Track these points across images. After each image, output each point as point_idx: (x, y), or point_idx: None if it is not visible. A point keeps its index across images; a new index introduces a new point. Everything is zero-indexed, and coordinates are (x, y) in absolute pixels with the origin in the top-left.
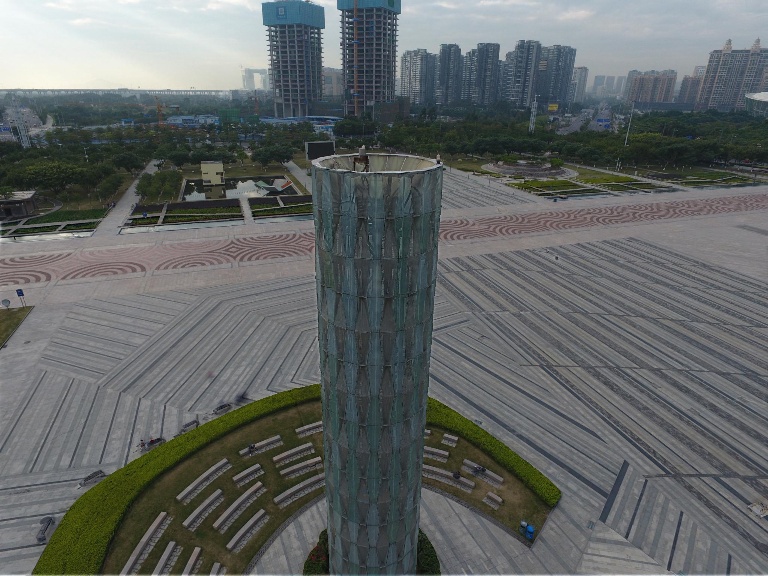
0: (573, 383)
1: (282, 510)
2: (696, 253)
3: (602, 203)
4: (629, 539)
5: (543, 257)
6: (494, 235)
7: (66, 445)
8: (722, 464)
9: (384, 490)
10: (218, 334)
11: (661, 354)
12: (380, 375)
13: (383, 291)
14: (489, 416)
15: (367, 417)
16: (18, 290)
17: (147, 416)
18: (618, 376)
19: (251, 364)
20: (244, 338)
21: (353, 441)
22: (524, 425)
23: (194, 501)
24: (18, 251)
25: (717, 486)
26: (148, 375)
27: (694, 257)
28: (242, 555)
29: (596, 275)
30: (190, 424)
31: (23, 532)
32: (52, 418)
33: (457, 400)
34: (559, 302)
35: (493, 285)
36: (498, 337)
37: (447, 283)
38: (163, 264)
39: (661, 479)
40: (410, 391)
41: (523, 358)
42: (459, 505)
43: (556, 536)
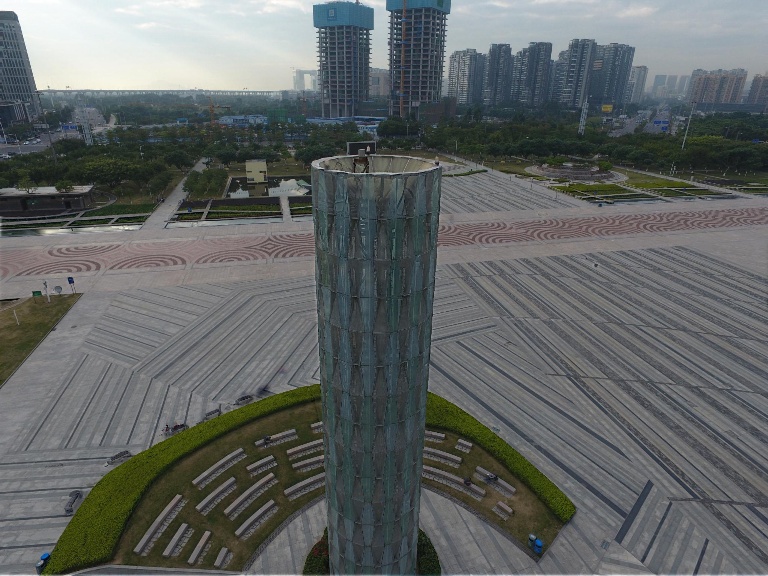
0: (600, 396)
1: (291, 502)
2: (752, 265)
3: (651, 209)
4: (645, 563)
5: (581, 264)
6: (531, 239)
7: (99, 425)
8: (758, 492)
9: (379, 490)
10: (247, 327)
11: (701, 371)
12: (373, 375)
13: (376, 292)
14: (508, 424)
15: (361, 416)
16: (69, 278)
17: (174, 402)
18: (650, 391)
19: (275, 358)
20: (271, 332)
21: (348, 439)
22: (544, 436)
23: (208, 487)
24: (74, 241)
25: (750, 515)
26: (179, 363)
27: (749, 269)
28: (249, 543)
29: (637, 284)
30: (212, 413)
31: (54, 503)
32: (89, 399)
33: (476, 406)
34: (594, 311)
35: (525, 291)
36: (525, 344)
37: (477, 287)
38: (202, 258)
39: (687, 503)
40: (405, 393)
41: (549, 367)
42: (467, 512)
43: (566, 553)
